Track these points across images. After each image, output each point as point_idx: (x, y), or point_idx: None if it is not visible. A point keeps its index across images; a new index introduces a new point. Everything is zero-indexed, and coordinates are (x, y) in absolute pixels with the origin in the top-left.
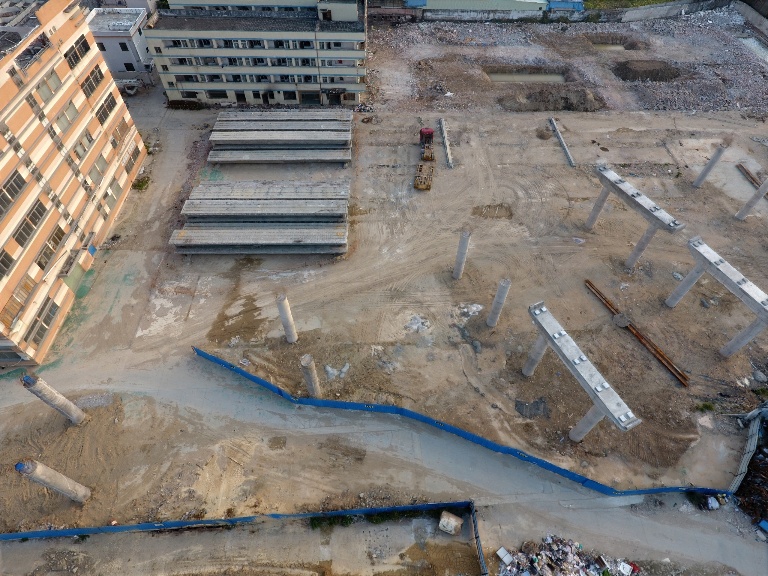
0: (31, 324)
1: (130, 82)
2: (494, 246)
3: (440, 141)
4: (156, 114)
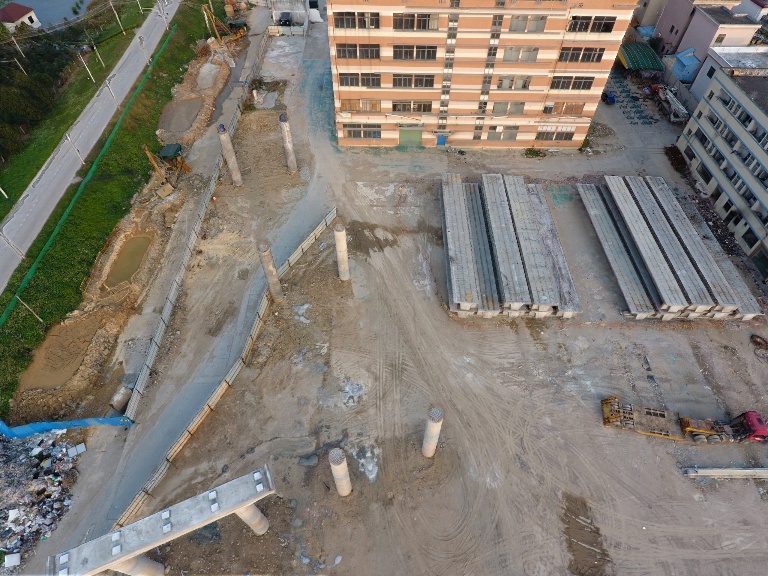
0: (354, 123)
1: (681, 110)
2: (495, 522)
3: (762, 461)
4: (649, 142)
